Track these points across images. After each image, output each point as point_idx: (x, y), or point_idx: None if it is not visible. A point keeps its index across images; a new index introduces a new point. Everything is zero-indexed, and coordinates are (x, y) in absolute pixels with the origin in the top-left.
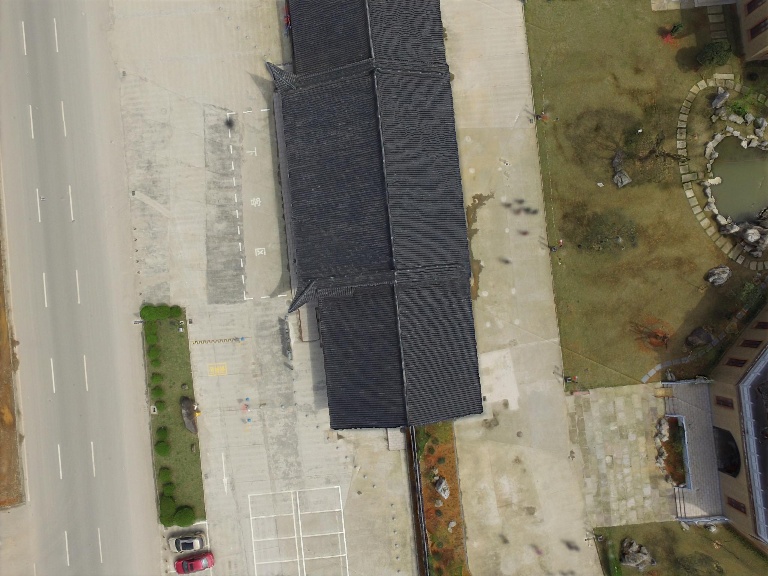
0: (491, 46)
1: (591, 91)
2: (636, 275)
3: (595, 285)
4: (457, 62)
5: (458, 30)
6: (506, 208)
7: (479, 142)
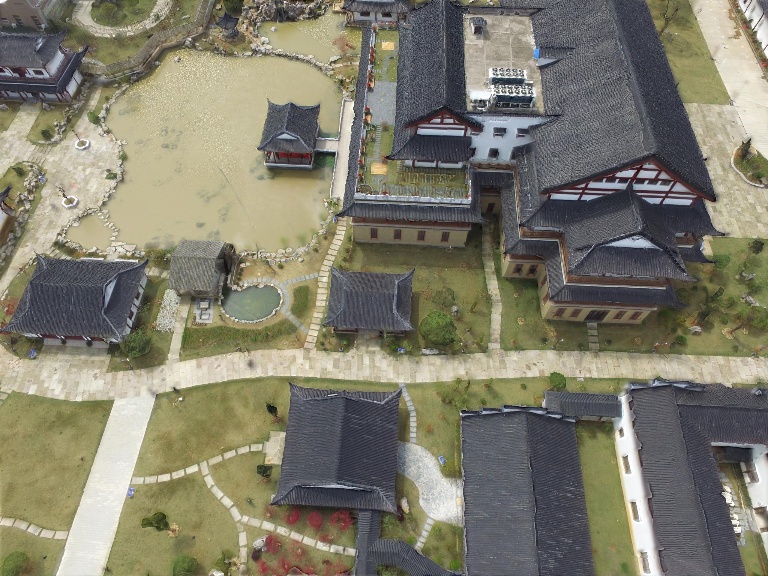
0: (744, 86)
1: (688, 63)
2: (655, 7)
3: (673, 7)
4: (762, 82)
5: (765, 94)
6: (721, 34)
7: (741, 55)
